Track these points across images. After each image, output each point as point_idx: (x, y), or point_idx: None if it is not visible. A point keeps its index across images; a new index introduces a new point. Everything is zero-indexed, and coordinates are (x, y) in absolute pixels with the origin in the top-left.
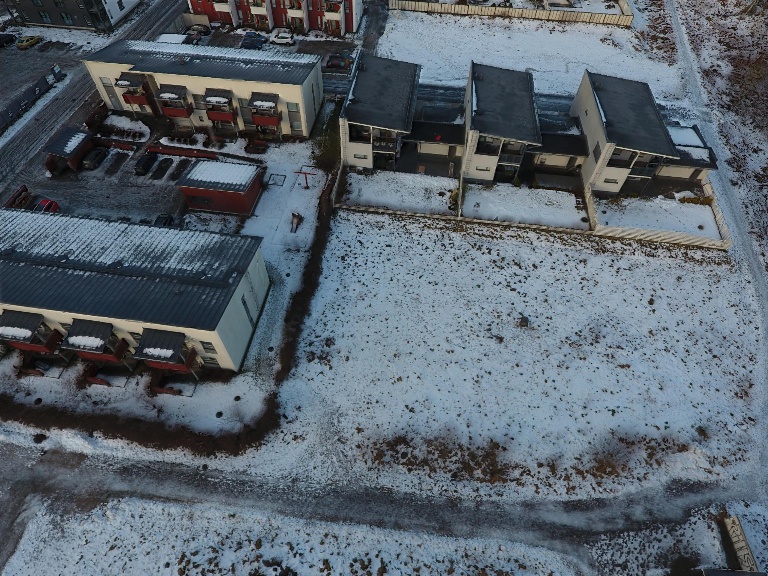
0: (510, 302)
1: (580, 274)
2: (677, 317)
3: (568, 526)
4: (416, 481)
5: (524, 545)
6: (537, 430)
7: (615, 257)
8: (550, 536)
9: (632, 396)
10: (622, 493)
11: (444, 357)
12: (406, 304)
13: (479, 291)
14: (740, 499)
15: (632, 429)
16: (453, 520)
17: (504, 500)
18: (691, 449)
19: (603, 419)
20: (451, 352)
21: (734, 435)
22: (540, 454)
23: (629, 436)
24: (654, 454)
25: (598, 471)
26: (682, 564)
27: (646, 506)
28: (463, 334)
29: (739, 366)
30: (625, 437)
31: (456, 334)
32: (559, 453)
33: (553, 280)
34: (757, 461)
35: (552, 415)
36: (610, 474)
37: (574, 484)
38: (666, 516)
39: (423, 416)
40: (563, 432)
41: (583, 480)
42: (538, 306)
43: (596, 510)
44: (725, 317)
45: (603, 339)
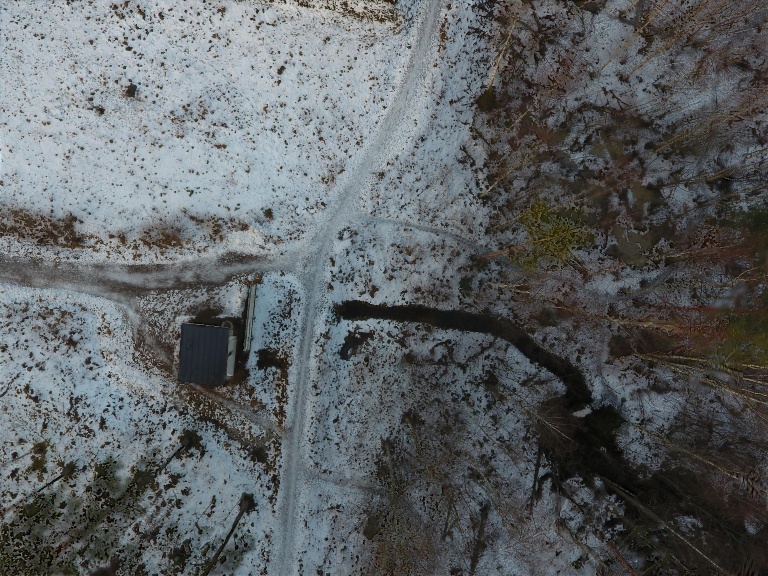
0: (122, 65)
1: (213, 29)
2: (302, 91)
3: (127, 284)
4: (5, 244)
5: (88, 295)
6: (115, 207)
7: (262, 5)
8: (110, 290)
9: (216, 178)
10: (180, 261)
11: (39, 129)
12: (6, 63)
13: (90, 49)
14: (279, 270)
15: (204, 209)
16: (33, 275)
17: (79, 262)
18: (250, 229)
19: (179, 199)
20: (47, 124)
21: (300, 218)
22: (113, 228)
23: (199, 215)
24: (220, 231)
25: (164, 243)
26: (207, 314)
27: (196, 272)
28: (63, 104)
29: (341, 150)
30: (195, 216)
31: (55, 103)
32: (130, 227)
33: (178, 37)
34: (309, 241)
35: (132, 193)
36: (175, 246)
37: (141, 253)
38: (210, 280)
39: (10, 189)
40: (138, 209)
41: (149, 250)
42: (152, 71)
43: (154, 273)
44: (356, 93)
45: (210, 115)
